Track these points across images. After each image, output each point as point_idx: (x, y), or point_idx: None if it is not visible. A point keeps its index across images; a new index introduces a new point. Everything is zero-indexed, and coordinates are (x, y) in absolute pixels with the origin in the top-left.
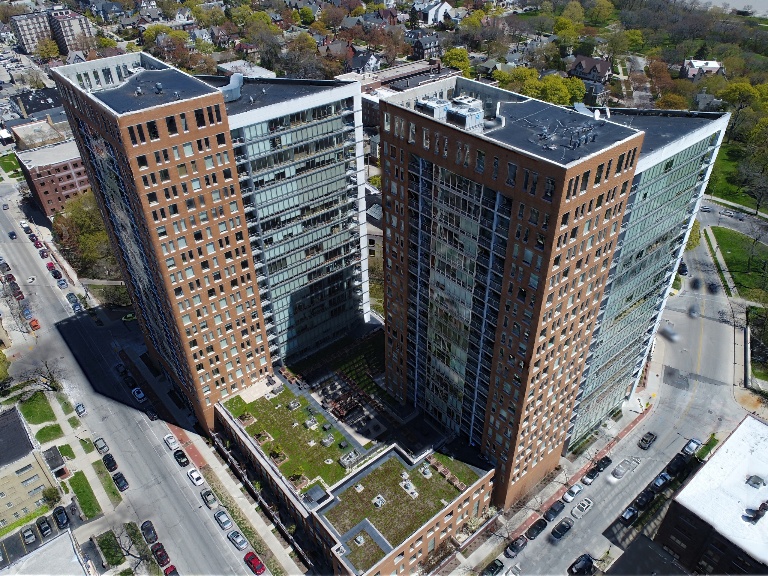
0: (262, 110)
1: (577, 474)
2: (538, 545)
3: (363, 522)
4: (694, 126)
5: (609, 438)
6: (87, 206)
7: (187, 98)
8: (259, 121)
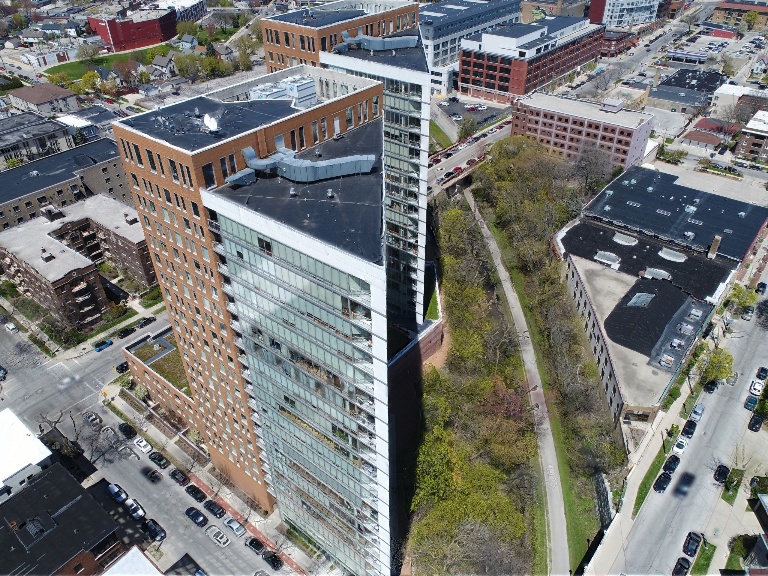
0: (343, 58)
1: (260, 532)
2: (181, 495)
3: (173, 347)
4: (347, 246)
5: (314, 572)
6: (508, 144)
7: (300, 24)
8: (340, 66)
